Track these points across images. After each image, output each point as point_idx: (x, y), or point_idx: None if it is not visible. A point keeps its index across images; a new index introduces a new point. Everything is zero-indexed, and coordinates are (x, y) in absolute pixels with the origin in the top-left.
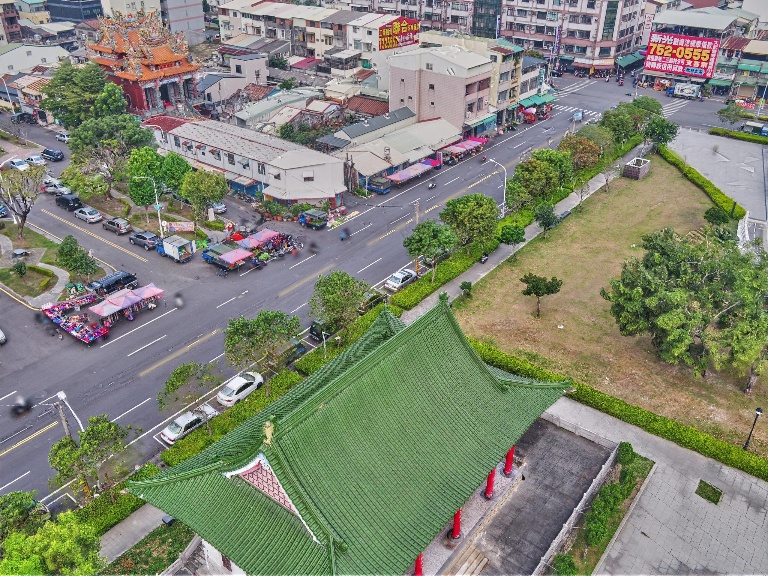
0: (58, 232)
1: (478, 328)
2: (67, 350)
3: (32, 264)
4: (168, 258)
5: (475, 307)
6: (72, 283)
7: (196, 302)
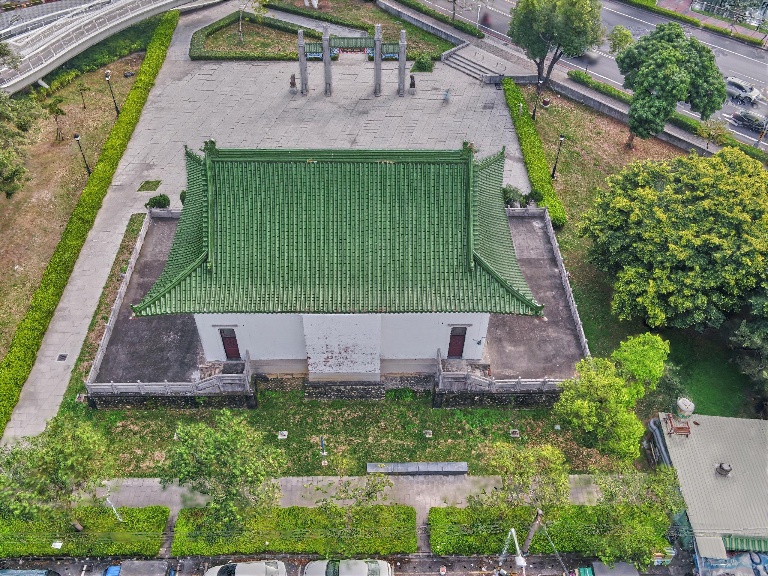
0: None
1: None
2: None
3: None
4: None
5: None
6: None
7: None
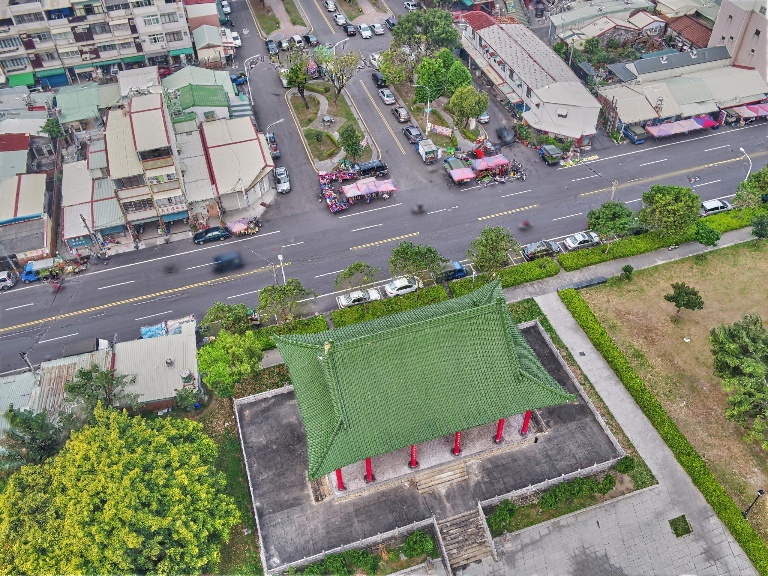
0: (361, 106)
1: (613, 310)
2: (320, 212)
3: (331, 131)
4: (420, 156)
5: (626, 290)
6: None
7: (417, 203)
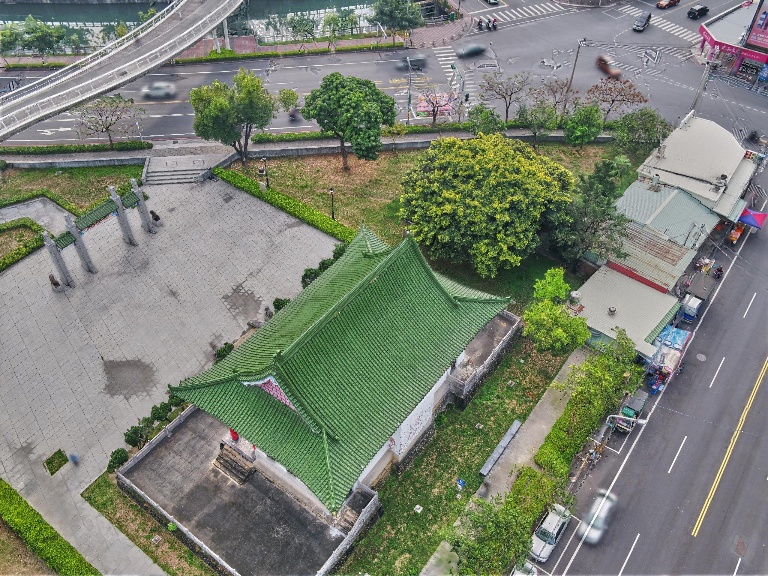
0: None
1: None
2: None
3: None
4: None
5: None
6: None
7: None
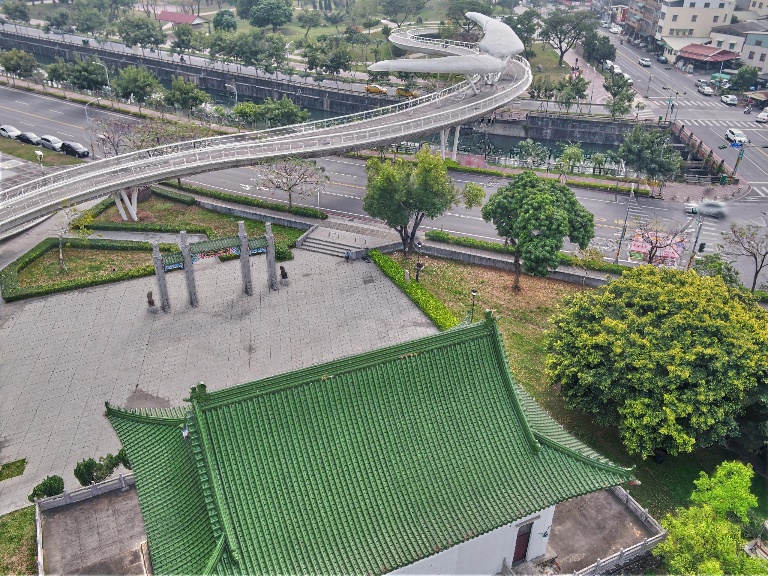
0: None
1: None
2: None
3: None
4: None
5: None
6: None
7: None
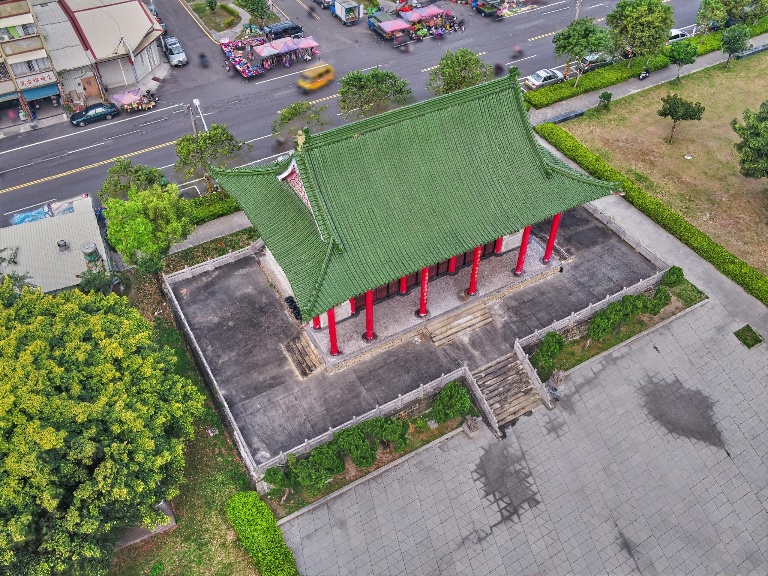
0: None
1: (599, 140)
2: (230, 80)
3: (225, 4)
4: (338, 19)
5: (607, 120)
6: (250, 25)
7: (346, 62)
